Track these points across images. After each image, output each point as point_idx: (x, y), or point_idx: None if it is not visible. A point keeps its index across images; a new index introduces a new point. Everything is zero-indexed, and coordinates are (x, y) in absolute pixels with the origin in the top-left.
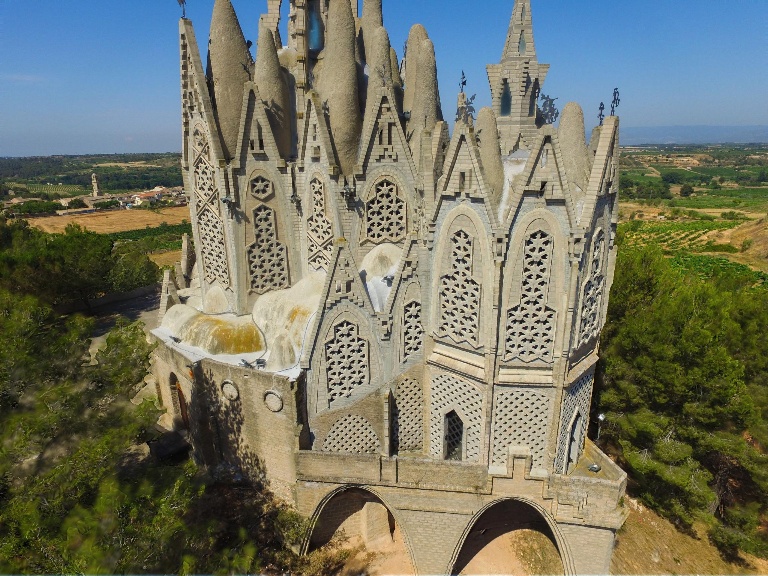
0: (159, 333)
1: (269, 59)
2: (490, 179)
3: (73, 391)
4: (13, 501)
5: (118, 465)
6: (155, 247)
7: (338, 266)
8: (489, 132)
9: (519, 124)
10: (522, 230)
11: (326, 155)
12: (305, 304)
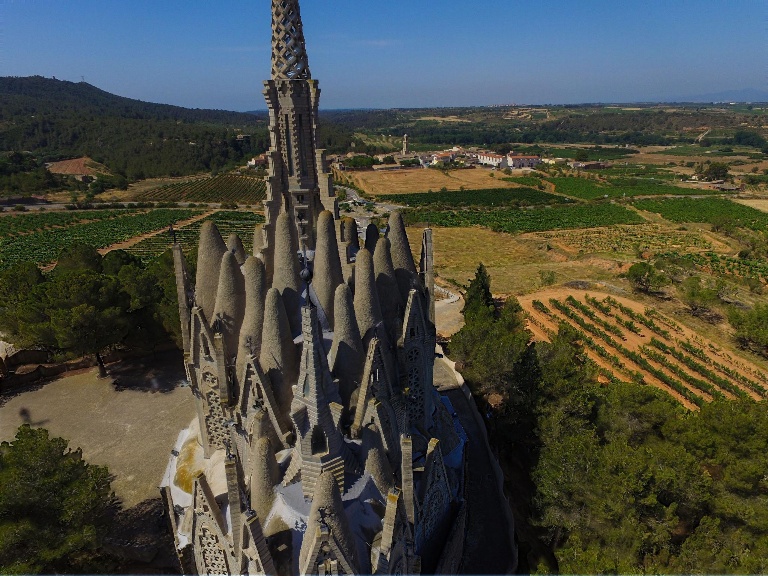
0: (180, 437)
1: (225, 280)
2: (253, 508)
3: None
4: None
5: (150, 512)
6: (415, 221)
7: (198, 491)
8: (257, 466)
9: (302, 459)
10: None
11: None
12: (212, 487)
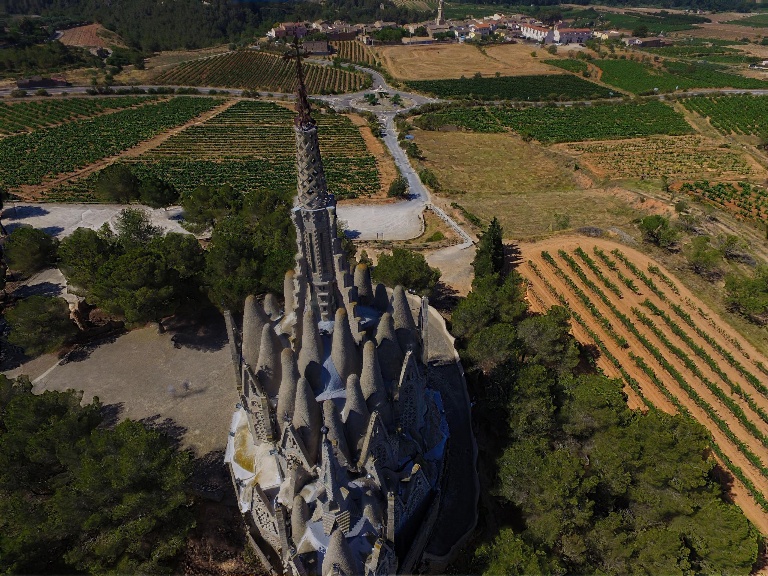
0: (234, 419)
1: (265, 345)
2: (293, 531)
3: (157, 478)
4: None
5: (215, 462)
6: (442, 125)
7: None
8: (295, 512)
9: (323, 511)
10: (294, 570)
11: (266, 430)
12: (262, 477)
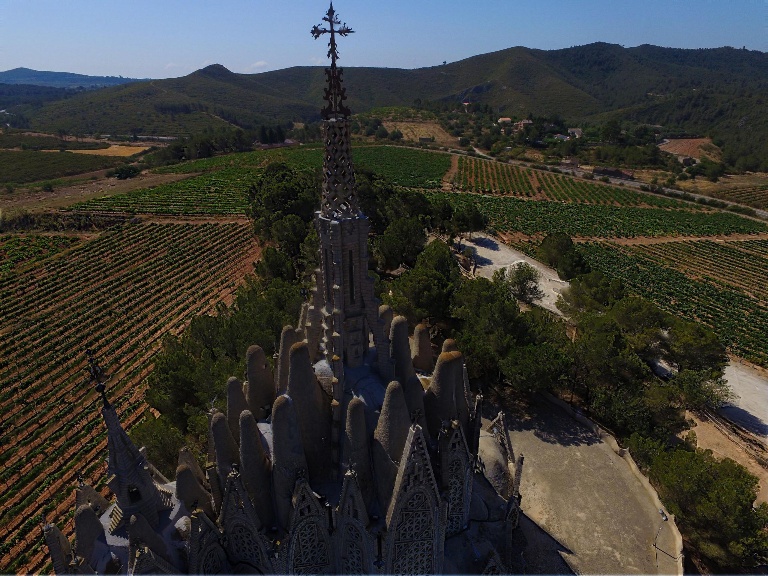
0: None
1: None
2: None
3: None
4: (205, 415)
5: None
6: None
7: None
8: None
9: None
10: None
11: None
12: None
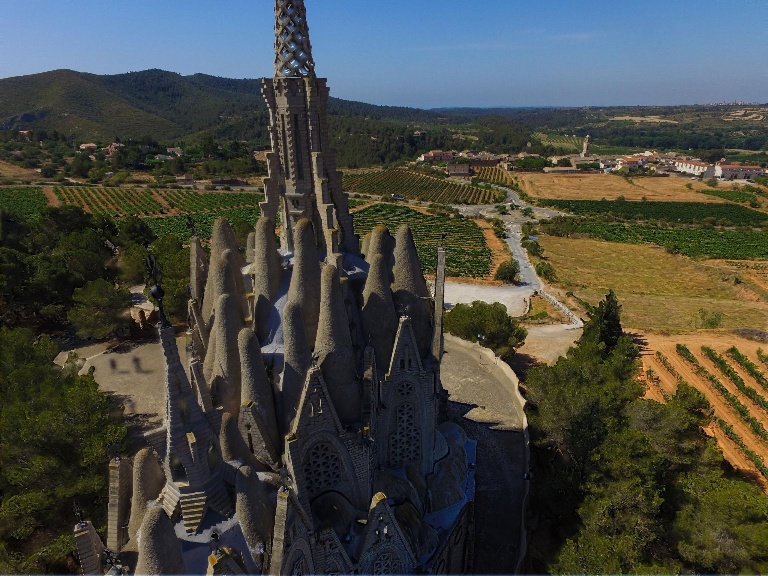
0: None
1: None
2: None
3: None
4: (12, 497)
5: None
6: (572, 231)
7: None
8: None
9: None
10: None
11: None
12: None
